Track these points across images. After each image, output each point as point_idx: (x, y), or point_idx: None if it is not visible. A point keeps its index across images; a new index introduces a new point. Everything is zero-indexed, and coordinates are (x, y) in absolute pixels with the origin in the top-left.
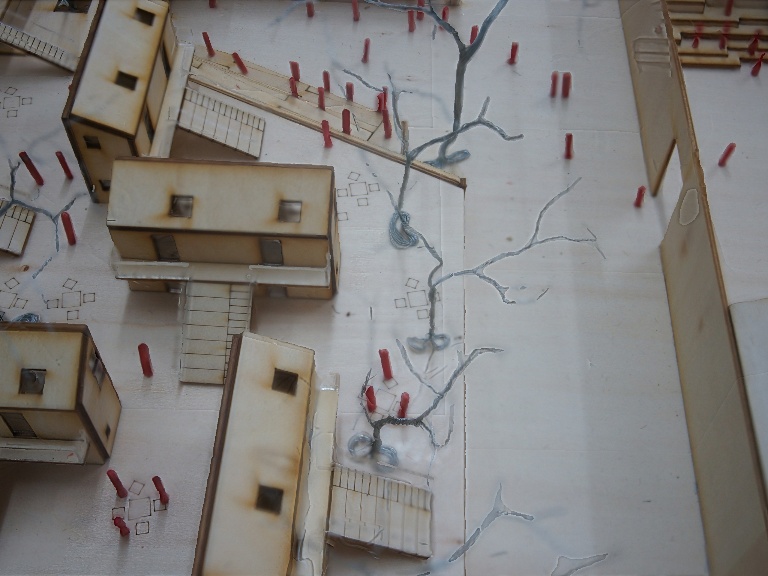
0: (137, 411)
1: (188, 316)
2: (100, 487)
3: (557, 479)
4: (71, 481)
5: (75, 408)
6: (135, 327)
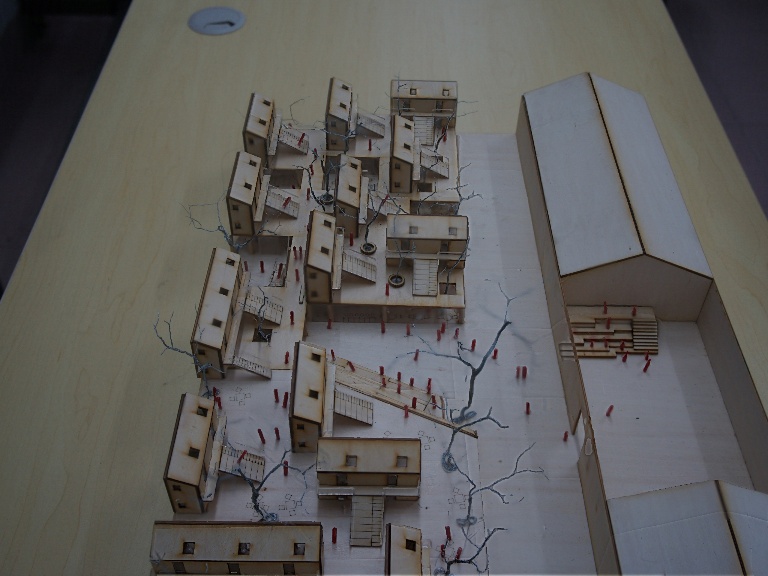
0: (332, 561)
1: (353, 513)
2: None
3: None
4: None
5: (319, 560)
6: (324, 518)
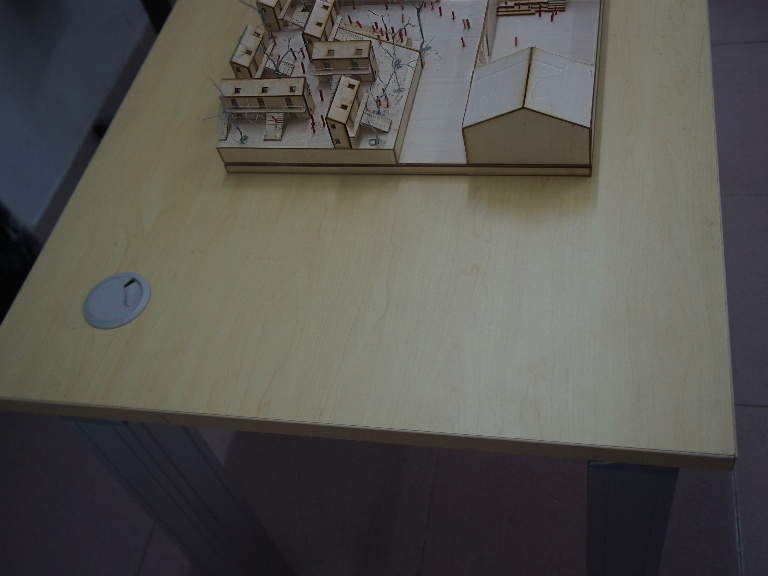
0: (319, 108)
1: (333, 84)
2: (309, 123)
3: (434, 126)
4: (302, 122)
5: (302, 95)
6: None
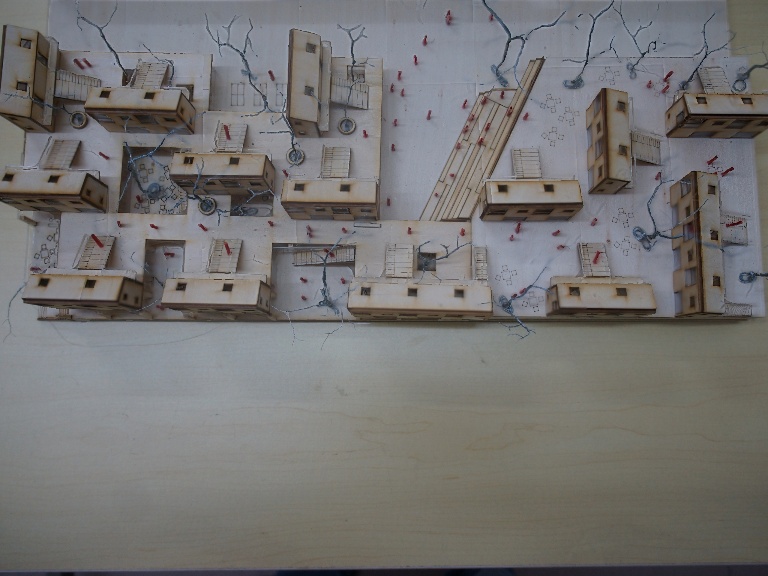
0: None
1: None
2: None
3: (661, 34)
4: None
5: None
6: (635, 188)
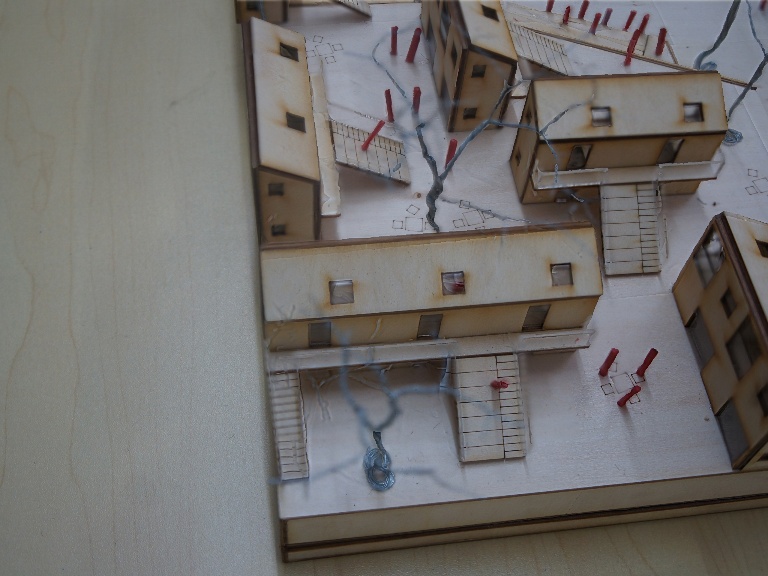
0: None
1: (605, 216)
2: (581, 370)
3: None
4: (555, 368)
5: None
6: None
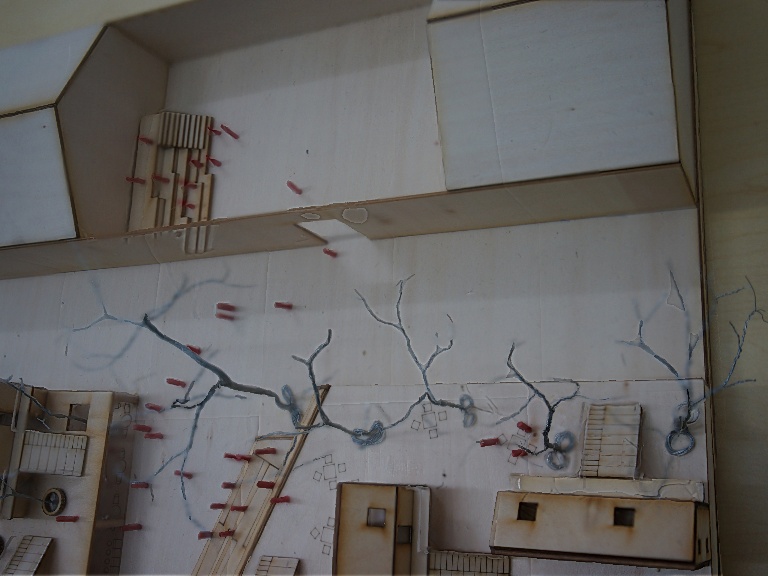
0: None
1: None
2: None
3: (563, 318)
4: None
5: None
6: None
